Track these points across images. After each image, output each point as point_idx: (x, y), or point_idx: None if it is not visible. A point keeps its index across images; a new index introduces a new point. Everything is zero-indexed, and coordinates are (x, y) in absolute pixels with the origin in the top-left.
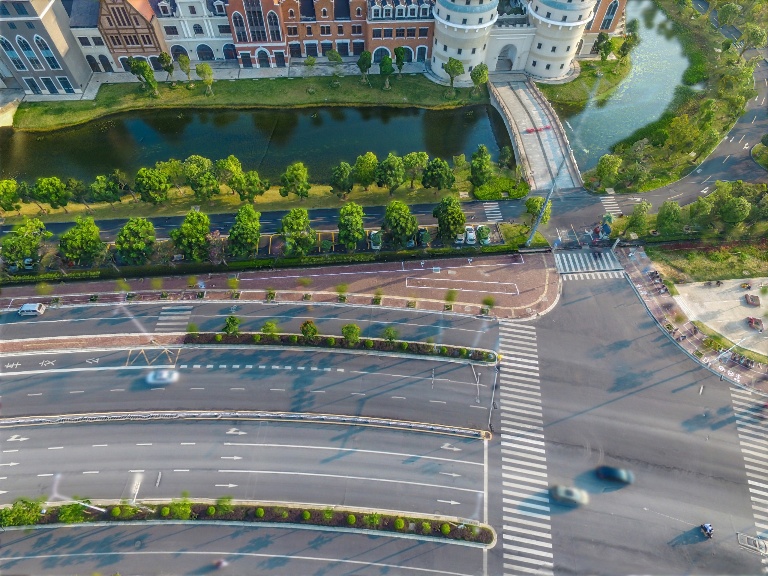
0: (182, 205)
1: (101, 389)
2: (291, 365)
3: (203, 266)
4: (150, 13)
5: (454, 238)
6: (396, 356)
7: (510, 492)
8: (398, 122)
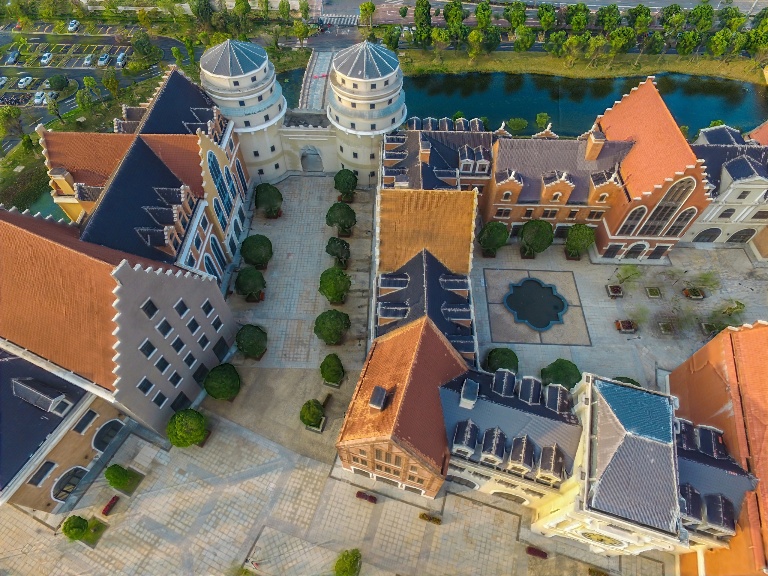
0: (601, 59)
1: (589, 0)
2: (505, 0)
3: (567, 29)
4: (761, 144)
5: None
6: None
7: None
8: (443, 116)
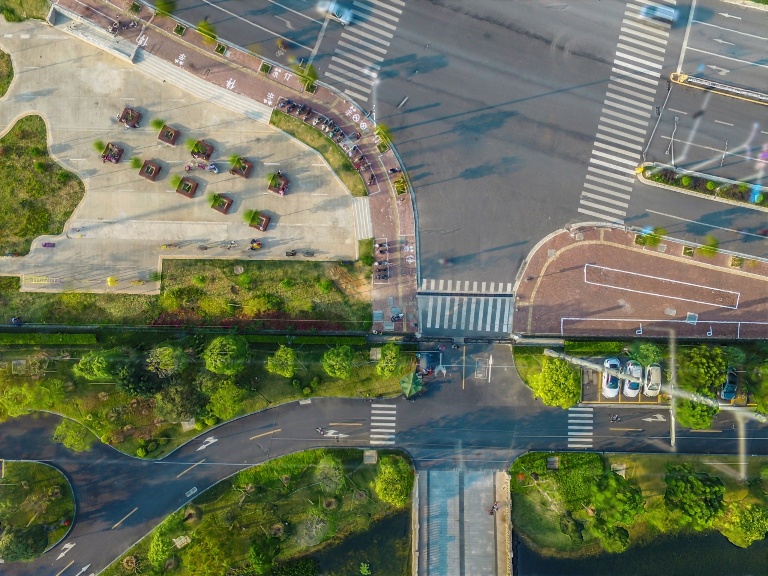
0: None
1: None
2: None
3: None
4: None
5: (664, 370)
6: (766, 188)
7: (666, 17)
8: None
